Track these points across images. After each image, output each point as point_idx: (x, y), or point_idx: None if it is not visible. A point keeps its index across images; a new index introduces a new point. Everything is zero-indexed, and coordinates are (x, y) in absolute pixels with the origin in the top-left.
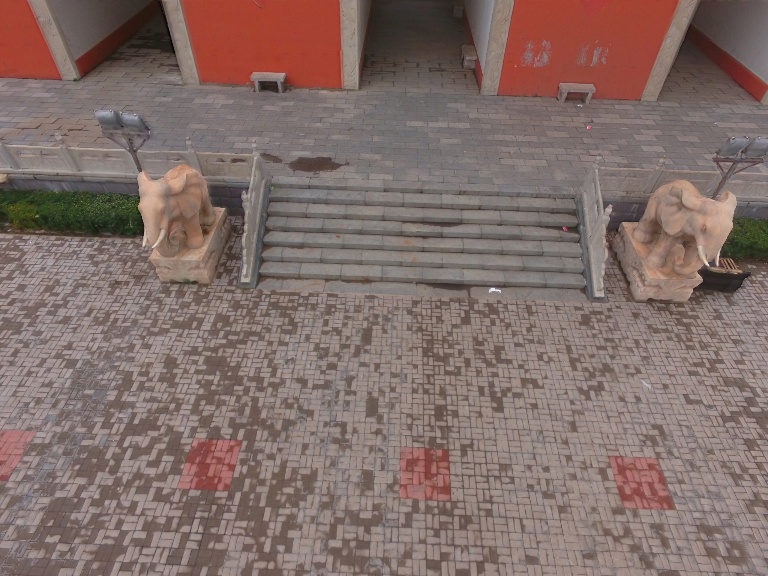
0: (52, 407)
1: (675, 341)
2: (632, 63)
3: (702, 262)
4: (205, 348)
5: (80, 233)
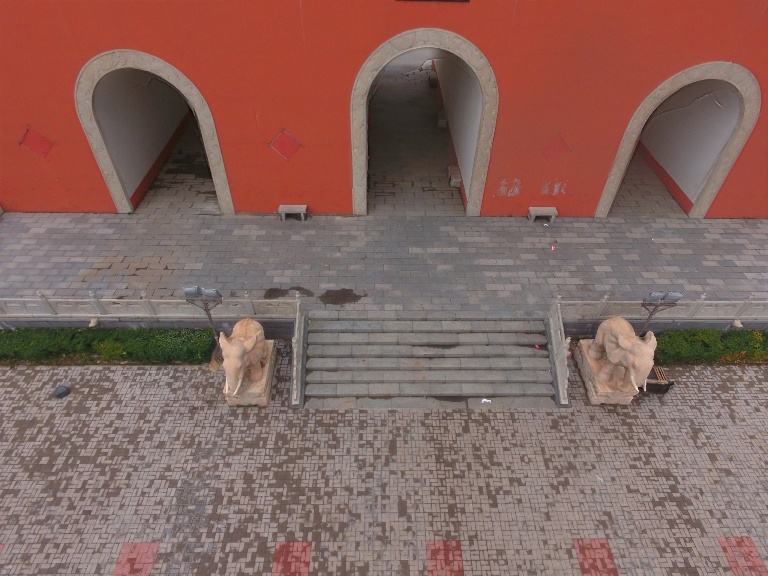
0: (166, 522)
1: (620, 439)
2: (585, 192)
3: (634, 388)
4: (272, 464)
5: (156, 362)
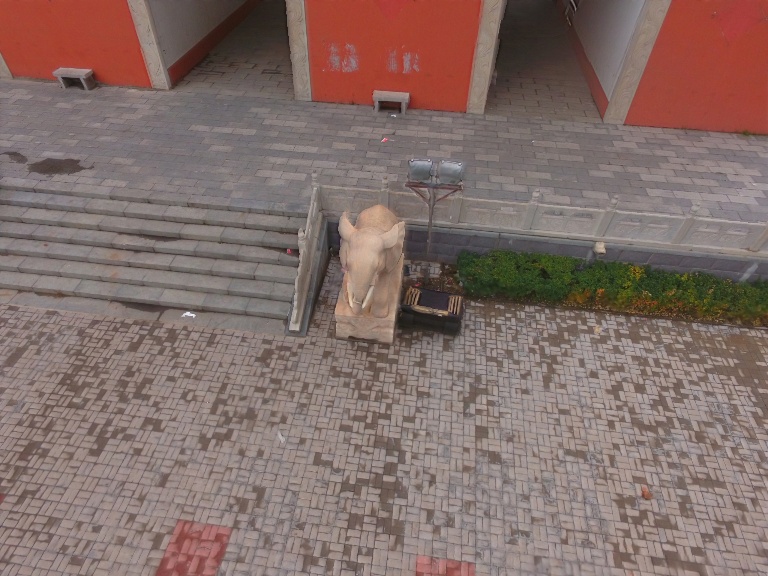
0: None
1: (350, 388)
2: (448, 71)
3: None
4: None
5: None
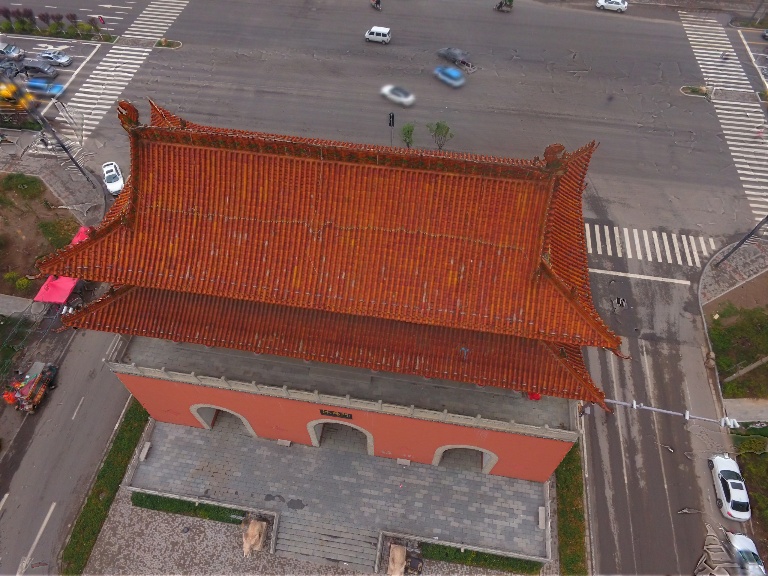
0: None
1: None
2: None
3: None
4: None
5: None
